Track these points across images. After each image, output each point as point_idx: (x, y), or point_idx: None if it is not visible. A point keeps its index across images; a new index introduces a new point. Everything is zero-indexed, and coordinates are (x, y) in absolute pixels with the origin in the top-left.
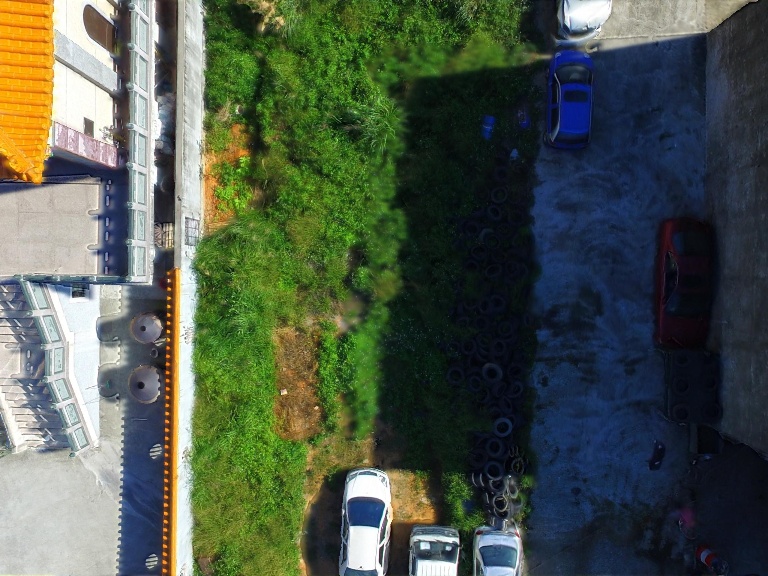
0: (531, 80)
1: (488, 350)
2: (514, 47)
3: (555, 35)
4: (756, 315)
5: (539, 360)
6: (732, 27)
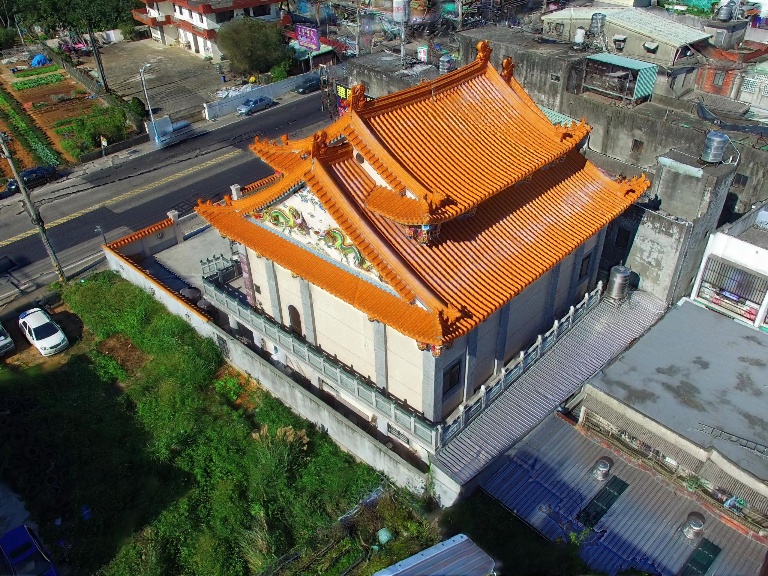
0: None
1: None
2: (99, 567)
3: None
4: None
5: None
6: None
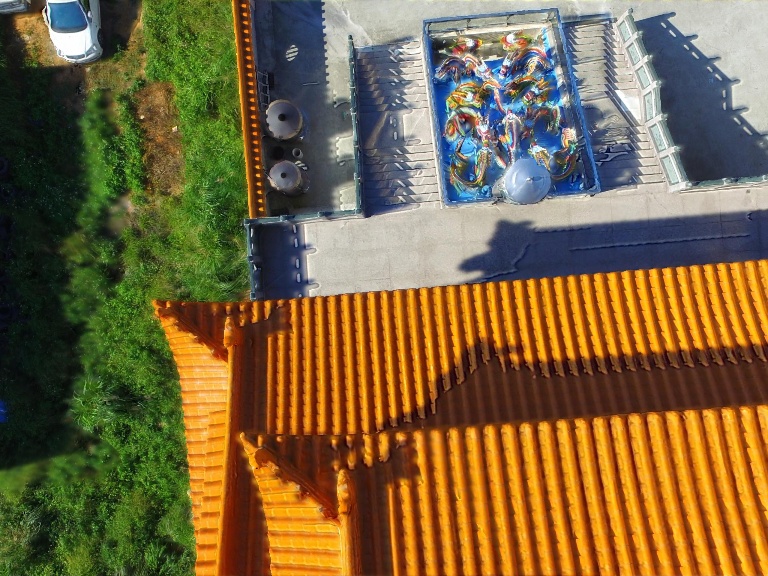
0: None
1: None
2: None
3: None
4: None
5: None
6: None
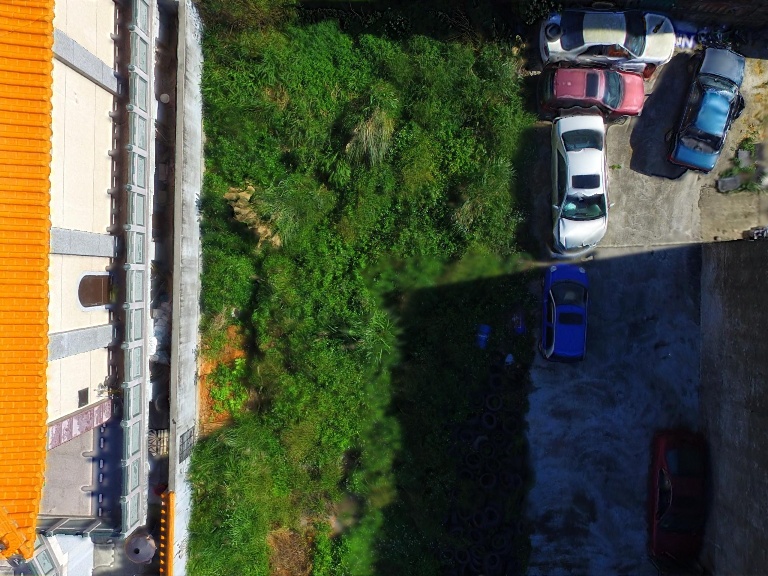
0: (526, 288)
1: (482, 562)
2: (510, 256)
3: (551, 247)
4: (749, 560)
5: (533, 565)
6: (727, 254)
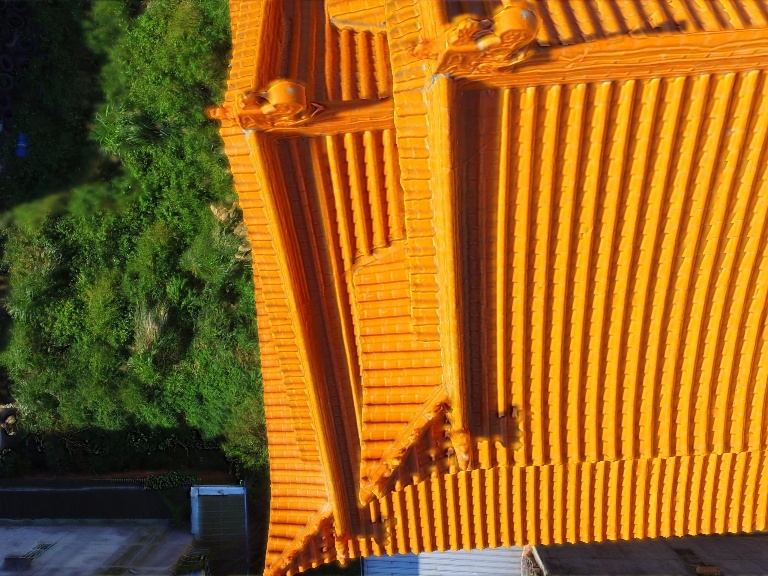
0: None
1: None
2: (7, 226)
3: None
4: None
5: None
6: None
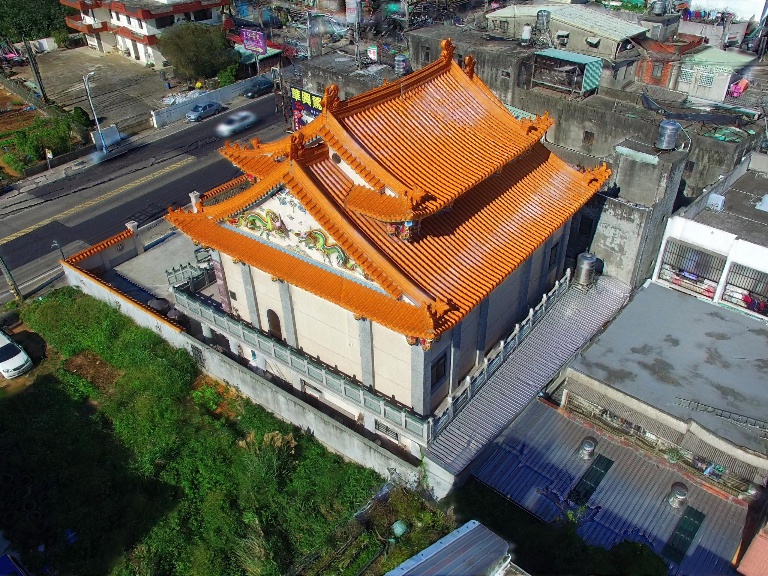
0: None
1: None
2: None
3: None
4: None
5: None
6: None
